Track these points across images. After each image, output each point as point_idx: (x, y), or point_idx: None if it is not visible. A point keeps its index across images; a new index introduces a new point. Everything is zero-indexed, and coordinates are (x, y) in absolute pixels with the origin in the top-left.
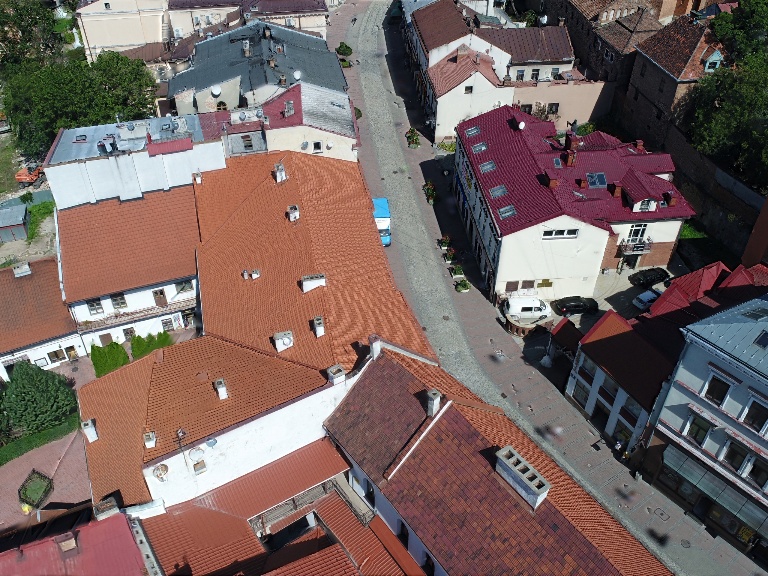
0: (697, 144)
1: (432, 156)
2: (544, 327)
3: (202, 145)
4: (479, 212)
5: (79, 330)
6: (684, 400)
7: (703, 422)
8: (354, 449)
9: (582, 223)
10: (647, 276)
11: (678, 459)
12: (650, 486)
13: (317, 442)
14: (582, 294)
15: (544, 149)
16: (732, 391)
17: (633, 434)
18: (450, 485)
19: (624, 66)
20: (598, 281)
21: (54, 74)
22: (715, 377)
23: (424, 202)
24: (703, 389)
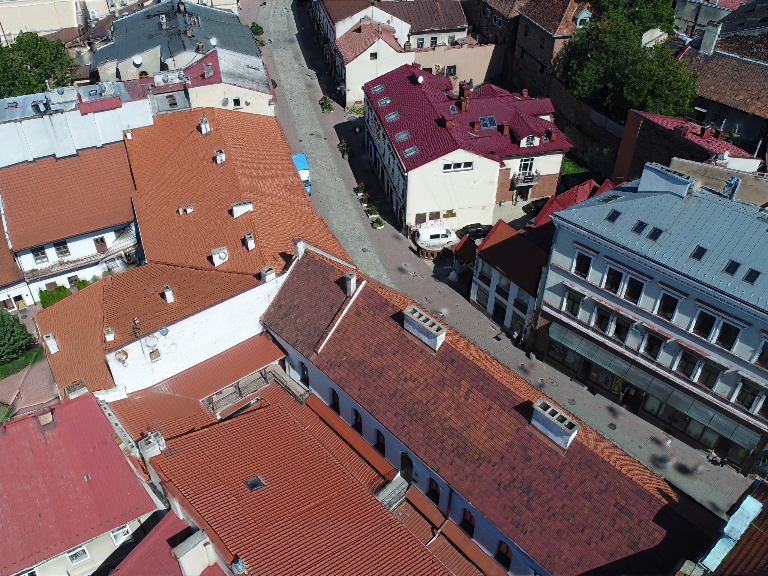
0: (573, 90)
1: (345, 119)
2: (450, 250)
3: (130, 103)
4: (388, 158)
5: (26, 278)
6: (560, 279)
7: (576, 295)
8: (288, 335)
9: (476, 156)
10: (537, 204)
11: (560, 332)
12: (542, 363)
13: (256, 337)
14: (482, 222)
15: (442, 99)
16: (593, 263)
17: (526, 321)
18: (369, 347)
19: (511, 29)
20: (496, 212)
21: None
22: (580, 253)
23: (340, 158)
24: (572, 266)
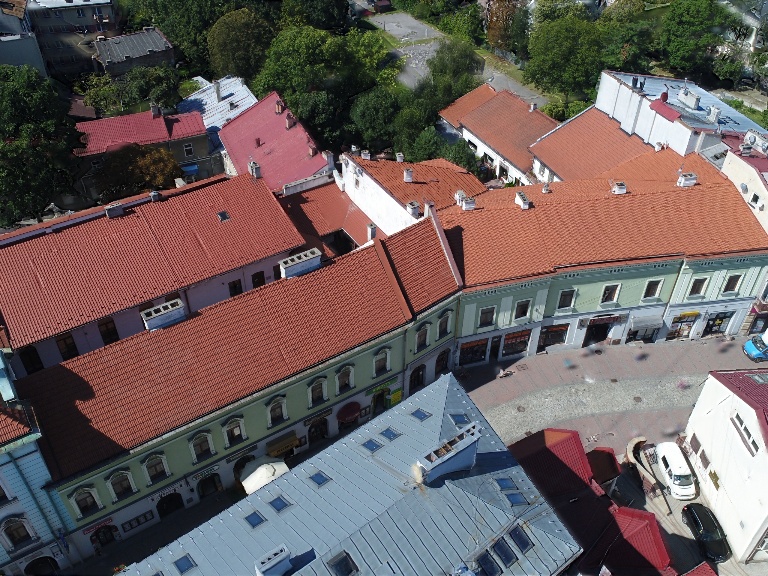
0: None
1: None
2: (642, 478)
3: (680, 124)
4: None
5: None
6: None
7: None
8: None
9: (764, 443)
10: None
11: None
12: None
13: None
14: (734, 541)
15: None
16: None
17: None
18: None
19: None
20: None
21: None
22: None
23: None
24: None
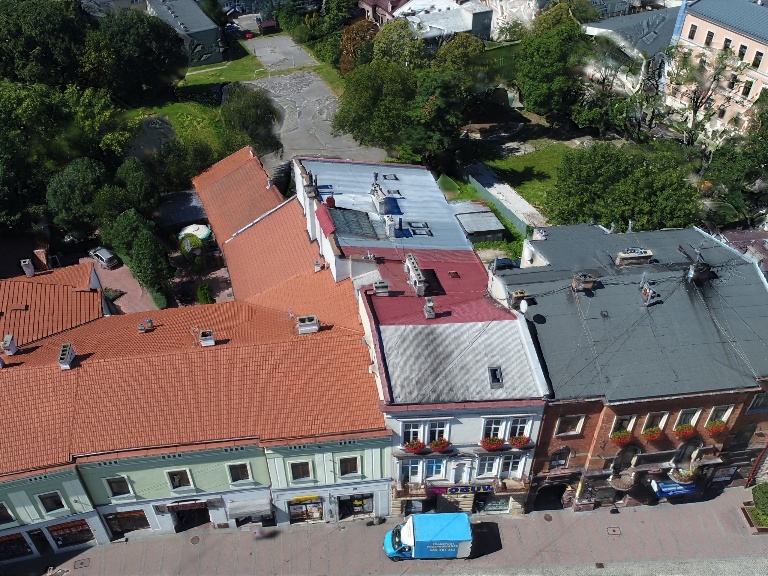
0: None
1: None
2: None
3: None
4: None
5: None
6: None
7: None
8: None
9: None
10: None
11: None
12: None
13: None
14: None
15: None
16: None
17: None
18: None
19: None
20: None
21: (598, 151)
22: None
23: None
24: None
